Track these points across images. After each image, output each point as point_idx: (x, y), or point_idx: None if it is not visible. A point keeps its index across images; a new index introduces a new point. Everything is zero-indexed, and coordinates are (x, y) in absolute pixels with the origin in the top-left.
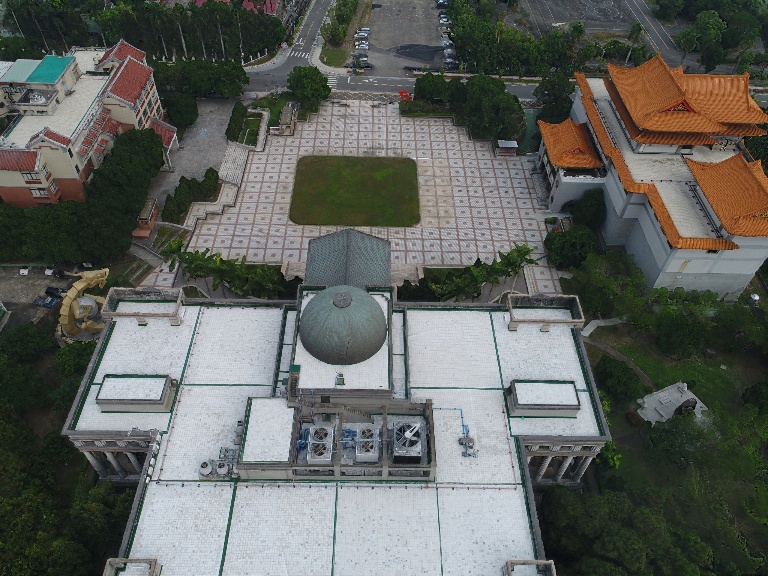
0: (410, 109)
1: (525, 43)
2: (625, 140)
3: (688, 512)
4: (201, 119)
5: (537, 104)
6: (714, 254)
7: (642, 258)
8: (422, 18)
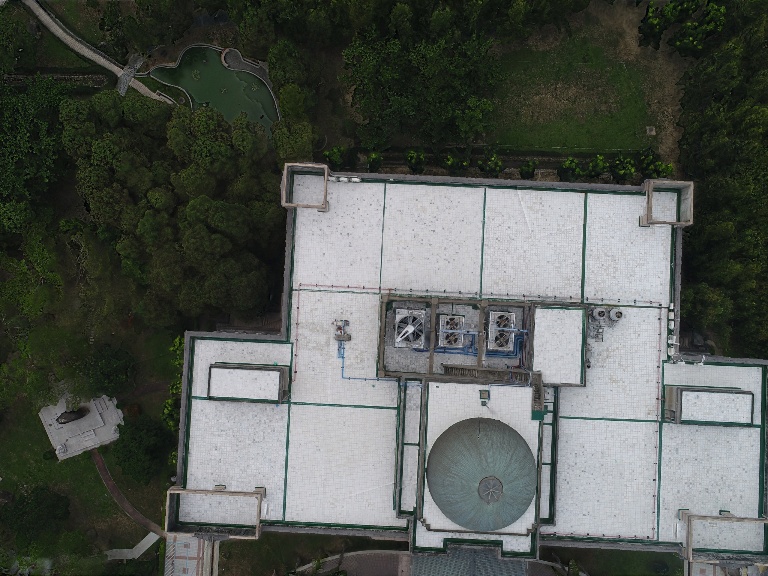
0: None
1: None
2: None
3: (123, 288)
4: None
5: None
6: None
7: None
8: None
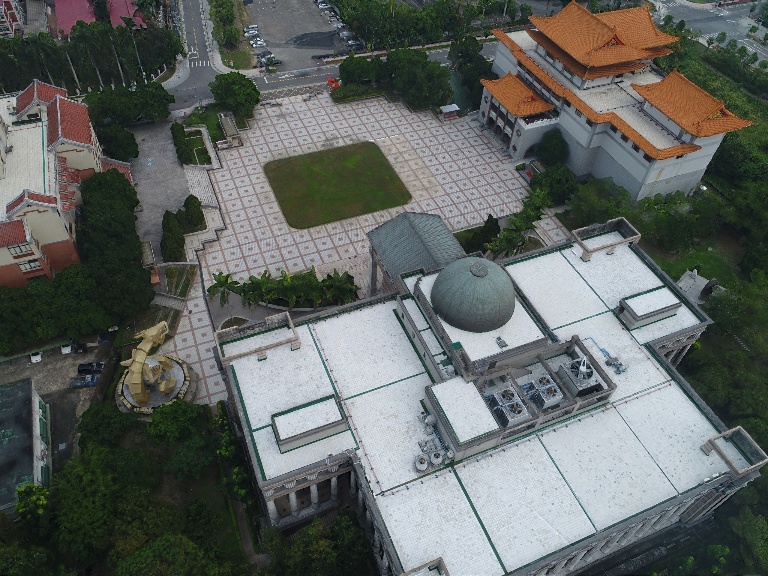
0: (343, 95)
1: (417, 13)
2: (567, 81)
3: (764, 363)
4: (138, 150)
5: (449, 68)
6: (680, 158)
7: (616, 178)
8: (300, 6)
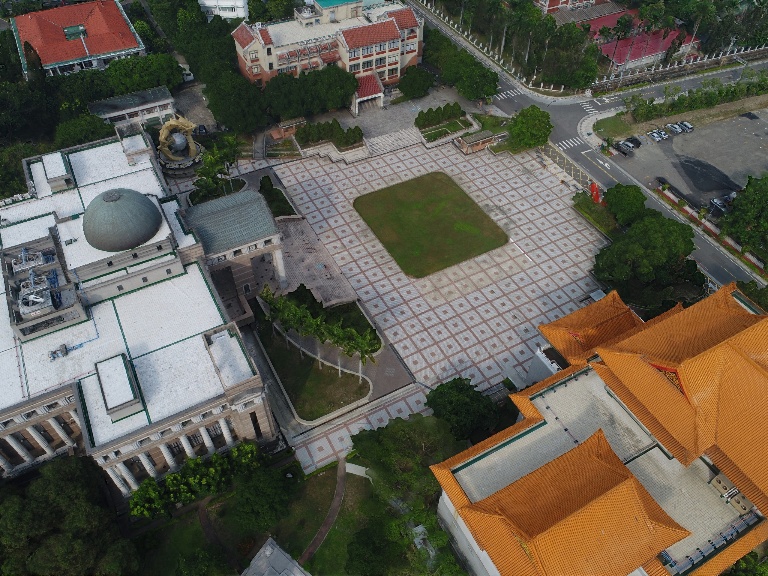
0: None
1: None
2: None
3: None
4: (430, 101)
5: None
6: None
7: None
8: None
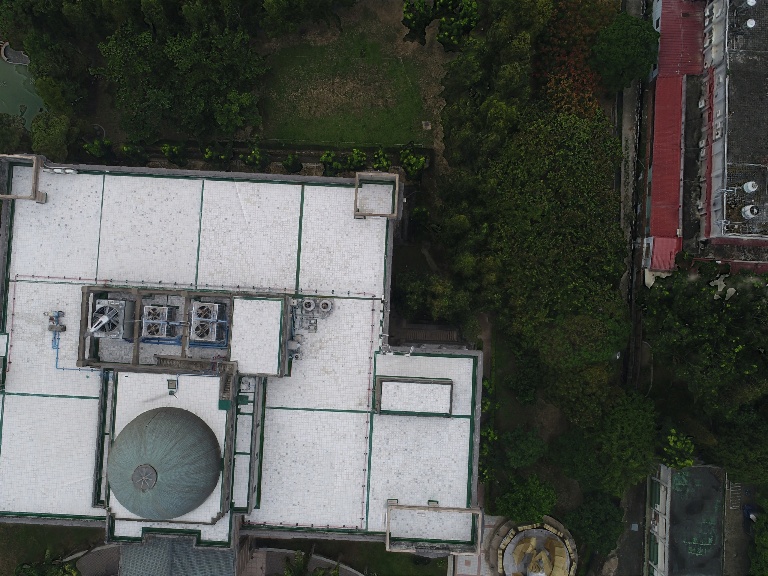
0: None
1: None
2: None
3: None
4: None
5: None
6: None
7: None
8: None
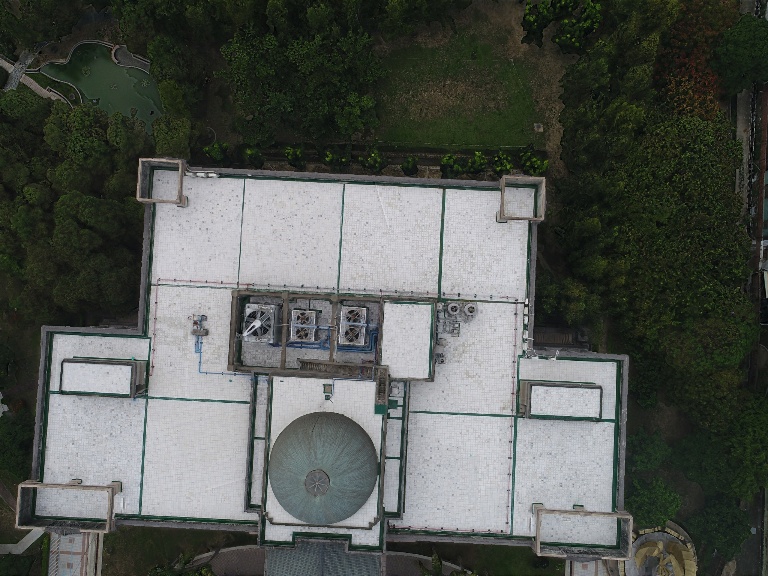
0: None
1: None
2: None
3: None
4: None
5: None
6: None
7: None
8: None
